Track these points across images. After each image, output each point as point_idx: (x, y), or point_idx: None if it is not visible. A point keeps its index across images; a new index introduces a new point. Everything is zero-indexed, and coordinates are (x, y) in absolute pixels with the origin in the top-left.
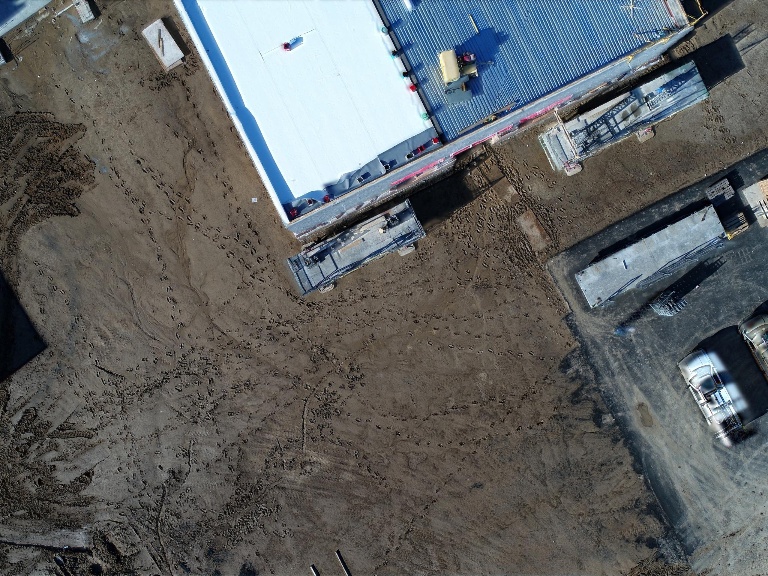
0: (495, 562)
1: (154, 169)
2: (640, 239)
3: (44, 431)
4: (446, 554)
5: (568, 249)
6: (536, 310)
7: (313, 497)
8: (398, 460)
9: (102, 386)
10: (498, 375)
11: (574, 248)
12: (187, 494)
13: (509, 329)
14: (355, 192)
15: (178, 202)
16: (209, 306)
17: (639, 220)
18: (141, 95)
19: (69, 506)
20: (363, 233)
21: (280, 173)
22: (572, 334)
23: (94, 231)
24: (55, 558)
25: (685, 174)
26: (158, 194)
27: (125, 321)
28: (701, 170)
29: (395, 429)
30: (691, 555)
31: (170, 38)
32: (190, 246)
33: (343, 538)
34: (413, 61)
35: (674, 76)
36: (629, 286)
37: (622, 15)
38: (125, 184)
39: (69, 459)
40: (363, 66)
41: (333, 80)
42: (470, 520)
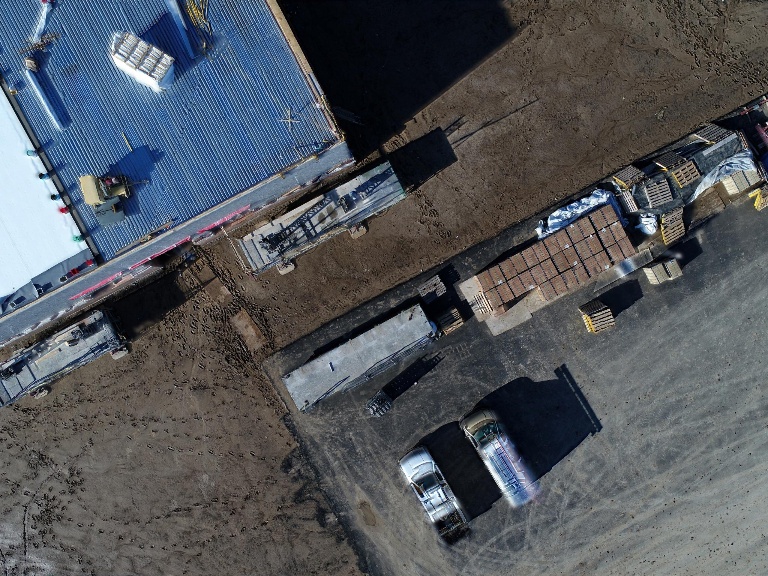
0: None
1: None
2: (348, 340)
3: None
4: None
5: (283, 349)
6: (255, 410)
7: None
8: (122, 564)
9: None
10: (220, 476)
11: (289, 348)
12: None
13: (229, 430)
14: (7, 318)
15: None
16: None
17: (354, 318)
18: None
19: None
20: (59, 343)
21: None
22: (291, 434)
23: None
24: None
25: (400, 270)
26: None
27: None
28: (416, 265)
29: (118, 533)
30: None
31: None
32: None
33: None
34: (66, 182)
35: (369, 177)
36: (337, 388)
37: (280, 129)
38: None
39: None
40: (13, 189)
41: None
42: None
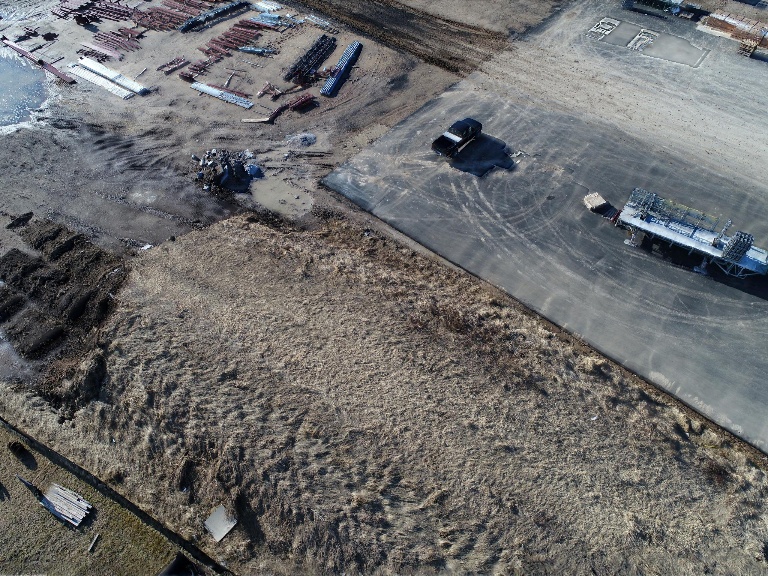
0: None
1: None
2: None
3: None
4: None
5: None
6: None
7: None
8: None
9: None
10: None
11: None
12: None
13: None
14: None
15: None
16: None
17: None
18: None
19: None
20: None
21: None
22: None
23: None
24: None
25: None
26: None
27: None
28: None
29: None
30: (519, 41)
31: None
32: None
33: None
34: None
35: None
36: None
37: None
38: None
39: None
40: None
41: None
42: None
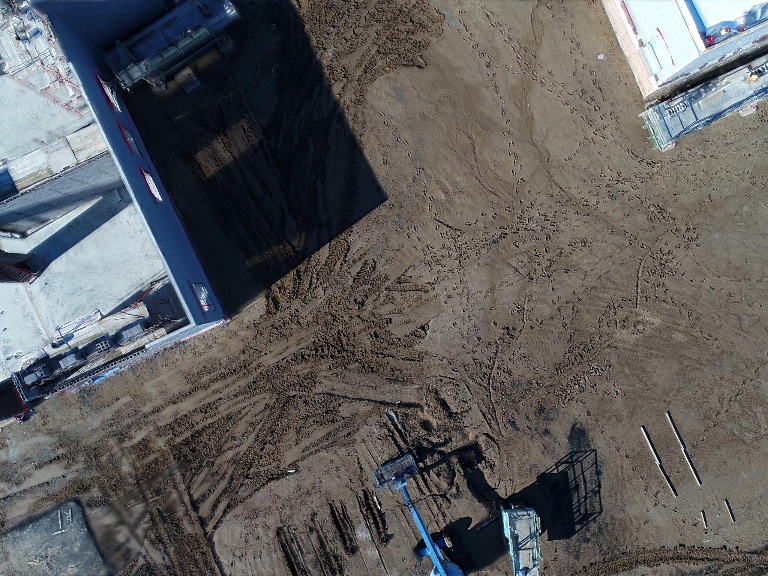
0: None
1: (502, 23)
2: None
3: (381, 283)
4: None
5: None
6: None
7: (645, 357)
8: (730, 322)
9: (440, 240)
10: None
11: None
12: (520, 351)
13: None
14: None
15: (524, 57)
16: (550, 162)
17: None
18: None
19: (403, 360)
20: (724, 85)
21: (692, 2)
22: None
23: (439, 83)
24: (387, 413)
25: None
26: (505, 48)
27: (466, 175)
28: None
29: (728, 290)
30: None
31: None
32: (534, 101)
33: (674, 399)
34: None
35: None
36: None
37: None
38: (472, 37)
39: (405, 312)
40: None
41: None
42: None
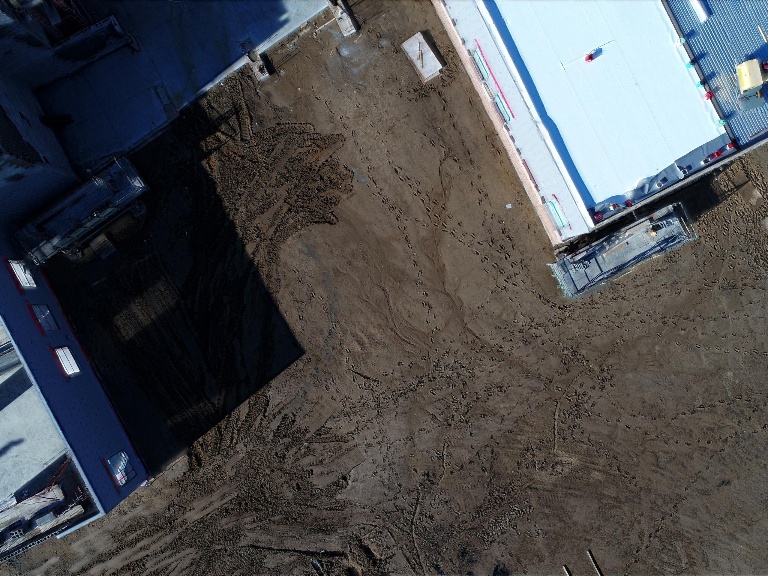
0: (743, 558)
1: (411, 177)
2: None
3: (302, 436)
4: (695, 551)
5: None
6: None
7: (565, 497)
8: (647, 459)
9: (358, 391)
10: (744, 374)
11: None
12: (441, 496)
13: (754, 329)
14: (656, 196)
15: (434, 209)
16: (463, 310)
17: None
18: (399, 106)
19: (326, 510)
20: (627, 237)
21: (581, 179)
22: None
23: (351, 238)
24: (312, 562)
25: None
26: (414, 202)
27: (381, 326)
28: None
29: (644, 429)
30: None
31: (429, 50)
32: (445, 252)
33: (594, 537)
34: (705, 70)
35: None
36: None
37: None
38: (382, 192)
39: (326, 463)
40: (659, 75)
41: (631, 89)
42: (718, 517)
